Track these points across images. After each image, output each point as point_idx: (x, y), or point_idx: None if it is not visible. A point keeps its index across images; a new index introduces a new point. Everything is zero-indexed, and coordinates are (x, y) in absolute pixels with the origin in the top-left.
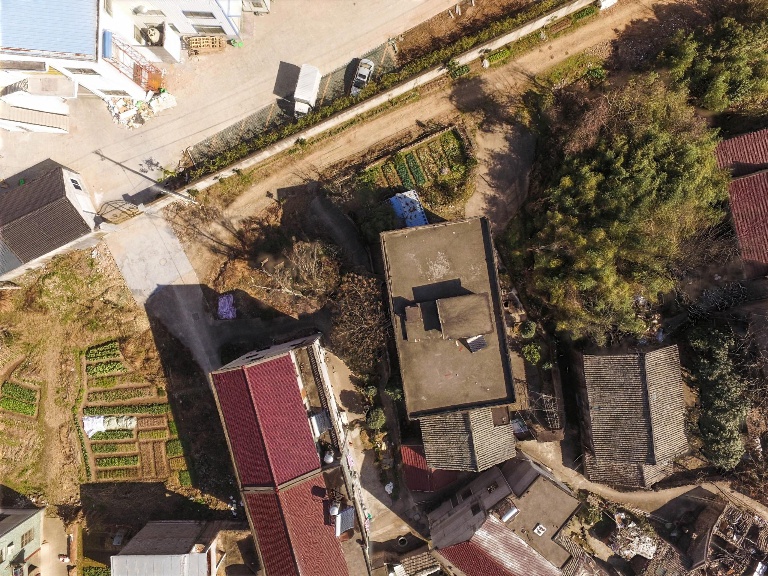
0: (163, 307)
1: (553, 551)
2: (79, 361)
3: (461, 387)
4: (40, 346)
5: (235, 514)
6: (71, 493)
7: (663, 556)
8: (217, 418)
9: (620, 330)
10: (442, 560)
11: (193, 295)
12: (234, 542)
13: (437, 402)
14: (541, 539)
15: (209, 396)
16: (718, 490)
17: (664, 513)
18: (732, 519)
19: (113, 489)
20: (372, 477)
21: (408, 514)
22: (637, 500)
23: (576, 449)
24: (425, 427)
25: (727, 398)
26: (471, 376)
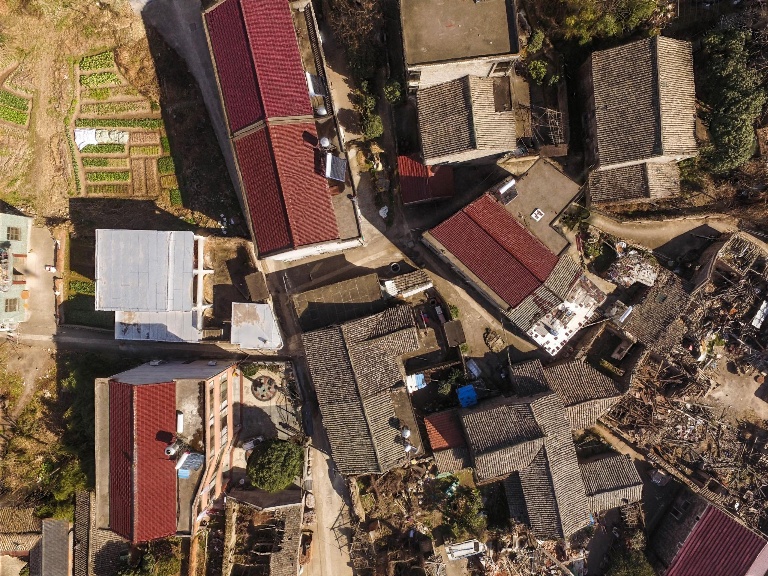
0: (160, 15)
1: (550, 238)
2: (73, 71)
3: (463, 39)
4: (34, 53)
5: (225, 232)
6: (60, 206)
7: (664, 283)
8: (211, 133)
9: (632, 20)
10: (435, 243)
11: (191, 4)
12: (223, 261)
13: (437, 54)
14: (538, 225)
15: (203, 109)
16: (725, 229)
17: (667, 251)
18: (738, 252)
19: (102, 203)
20: (367, 200)
21: (402, 241)
22: (640, 236)
23: (579, 180)
24: (423, 116)
25: (741, 87)
26: (474, 28)
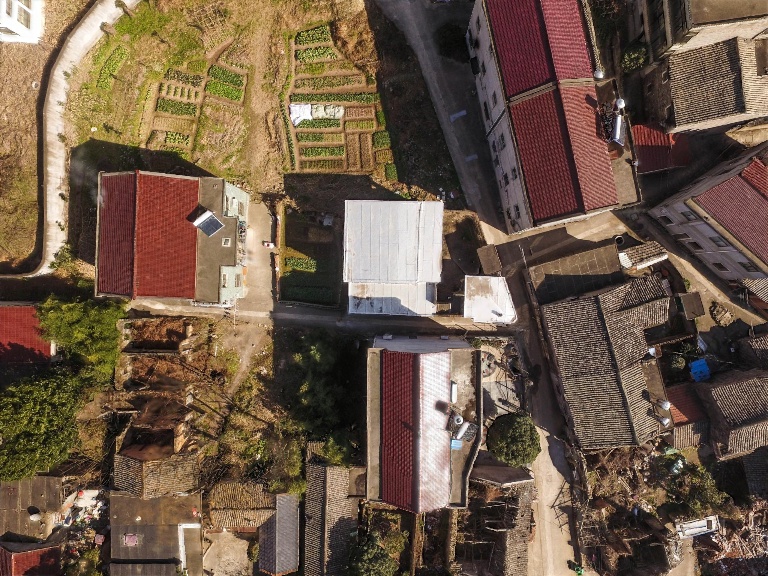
0: None
1: None
2: (288, 46)
3: None
4: (249, 28)
5: None
6: (274, 182)
7: None
8: (429, 106)
9: None
10: (698, 210)
11: None
12: (442, 236)
13: (720, 14)
14: None
15: (423, 82)
16: None
17: None
18: None
19: (318, 179)
20: None
21: (625, 213)
22: None
23: None
24: (676, 82)
25: None
26: None
